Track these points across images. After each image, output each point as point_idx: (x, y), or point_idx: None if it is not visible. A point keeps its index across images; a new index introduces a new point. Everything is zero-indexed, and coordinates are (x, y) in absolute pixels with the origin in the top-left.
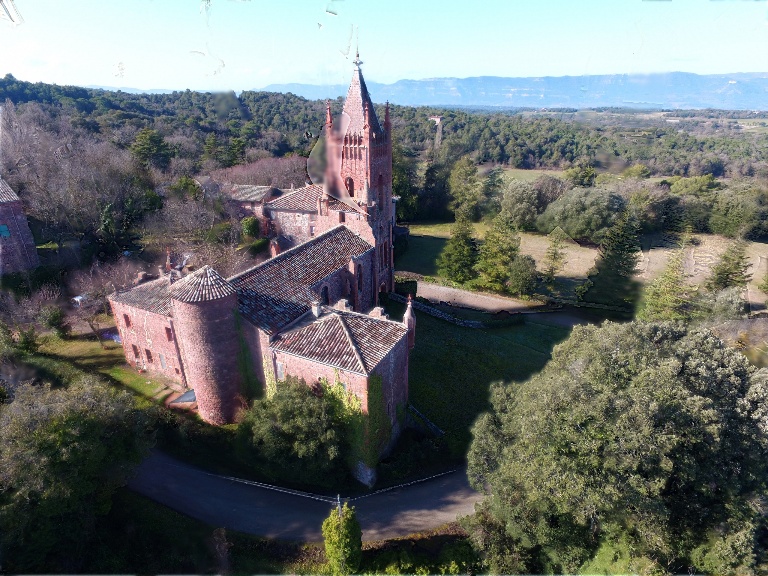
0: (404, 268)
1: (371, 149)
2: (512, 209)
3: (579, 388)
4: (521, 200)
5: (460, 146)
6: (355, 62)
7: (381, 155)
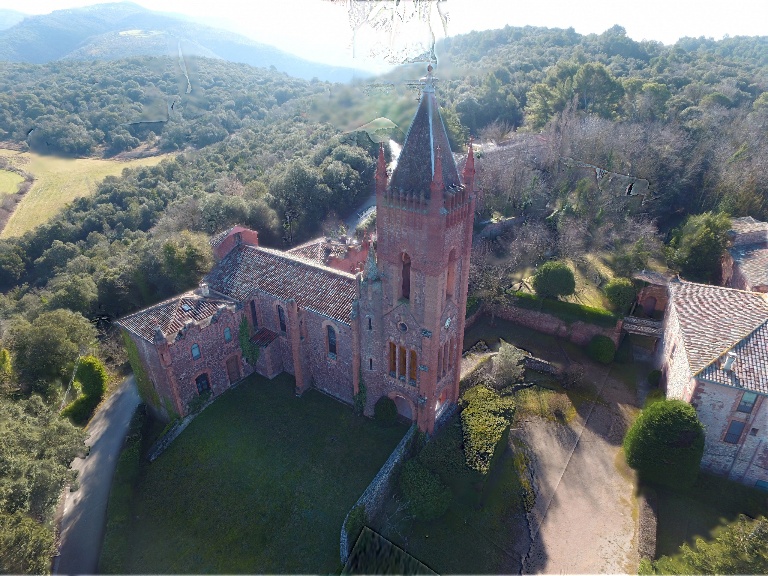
0: None
1: (382, 207)
2: None
3: None
4: None
5: None
6: None
7: (407, 225)
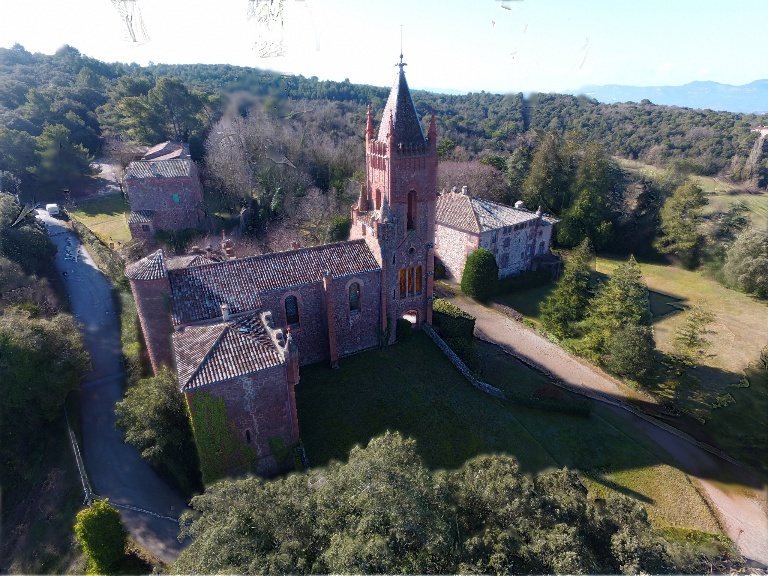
0: (518, 303)
1: (395, 161)
2: (739, 263)
3: (204, 503)
4: (756, 253)
5: (693, 168)
6: (397, 64)
7: (414, 168)
